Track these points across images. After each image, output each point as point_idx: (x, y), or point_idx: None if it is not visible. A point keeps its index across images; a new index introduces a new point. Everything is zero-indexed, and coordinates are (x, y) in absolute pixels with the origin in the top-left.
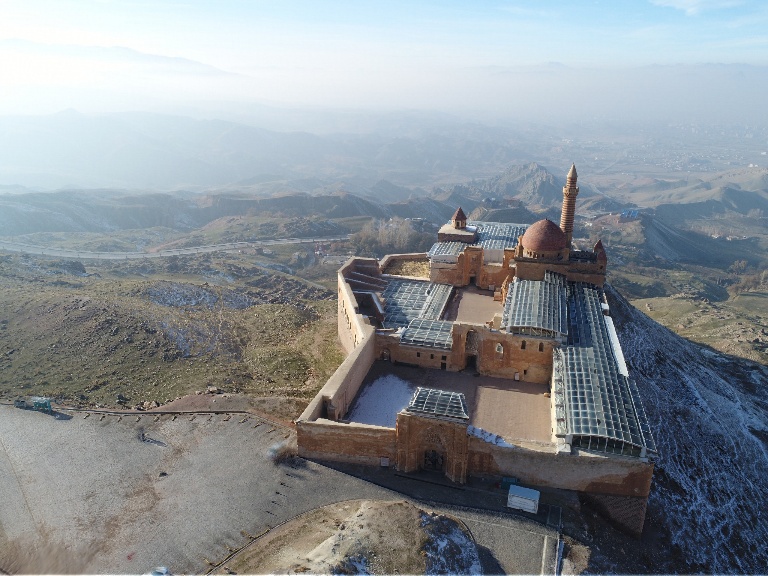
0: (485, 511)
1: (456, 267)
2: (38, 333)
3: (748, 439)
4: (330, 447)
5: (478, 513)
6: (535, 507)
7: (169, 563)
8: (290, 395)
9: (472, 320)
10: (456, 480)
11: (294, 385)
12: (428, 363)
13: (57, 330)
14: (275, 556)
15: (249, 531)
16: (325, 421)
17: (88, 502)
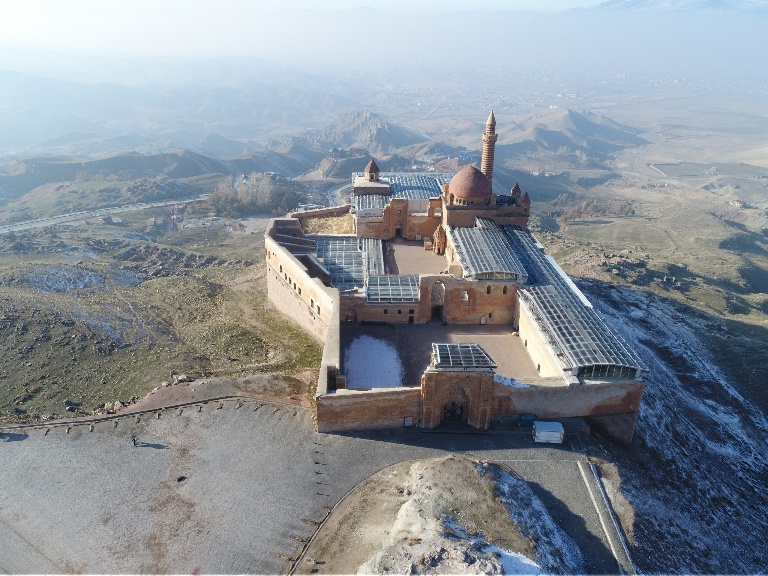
0: (518, 450)
1: (383, 220)
2: None
3: (641, 348)
4: (352, 417)
5: (513, 453)
6: (561, 438)
7: (244, 569)
8: (264, 371)
9: (414, 271)
10: (480, 426)
11: (259, 360)
12: (396, 319)
13: None
14: (355, 536)
15: (310, 517)
16: (346, 391)
17: (109, 526)
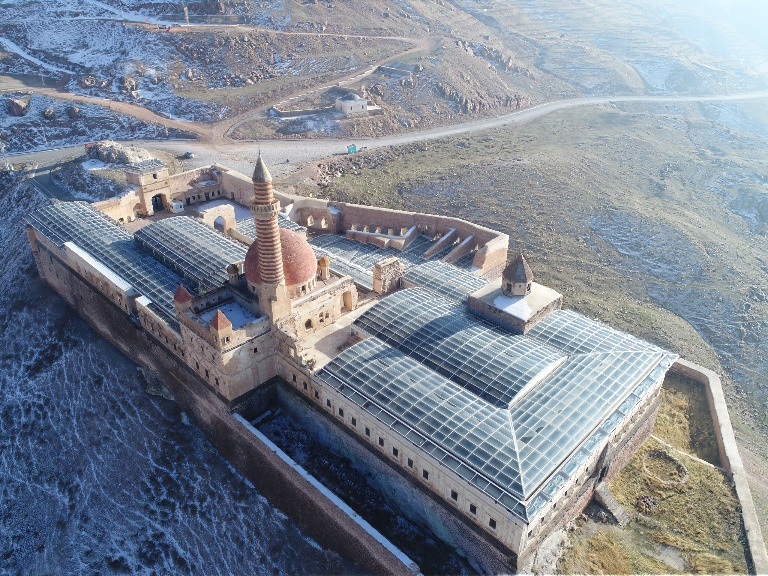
0: None
1: None
2: None
3: None
4: None
5: None
6: None
7: None
8: None
9: None
10: None
11: None
12: None
13: None
14: None
15: None
16: None
17: None
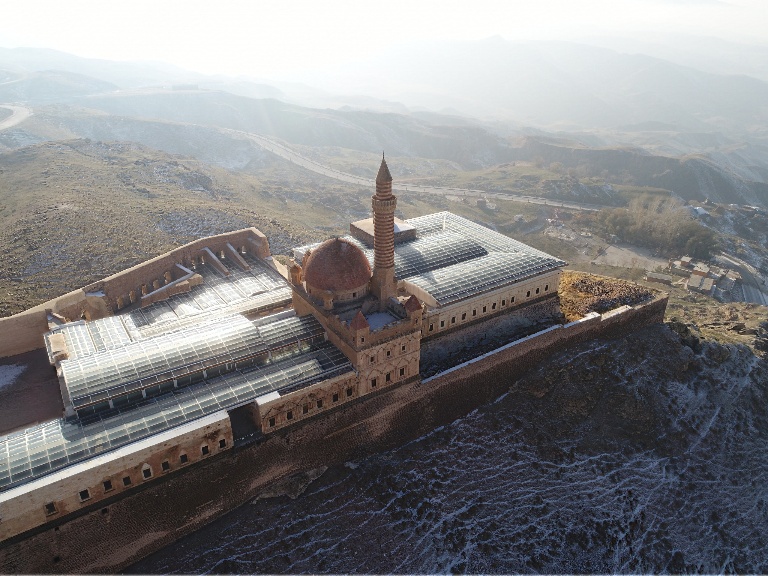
0: None
1: (302, 273)
2: (1, 226)
3: None
4: None
5: None
6: None
7: None
8: None
9: None
10: None
11: None
12: None
13: (7, 227)
14: None
15: None
16: None
17: None
